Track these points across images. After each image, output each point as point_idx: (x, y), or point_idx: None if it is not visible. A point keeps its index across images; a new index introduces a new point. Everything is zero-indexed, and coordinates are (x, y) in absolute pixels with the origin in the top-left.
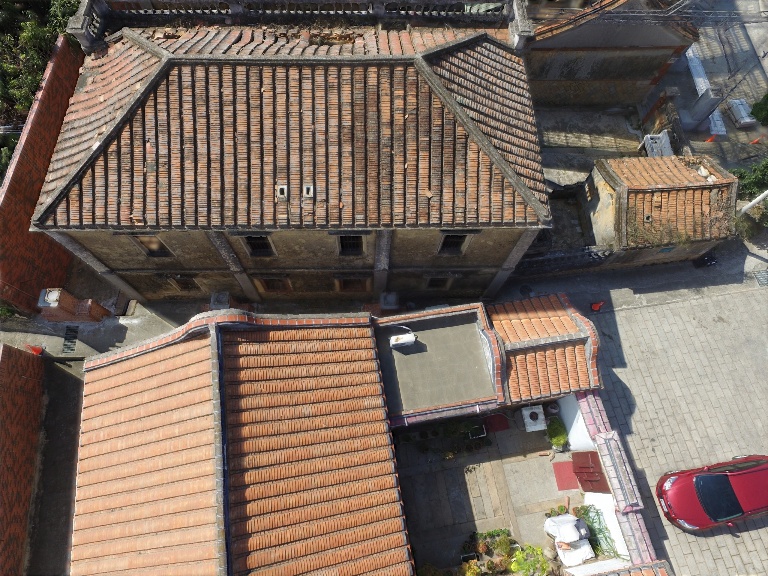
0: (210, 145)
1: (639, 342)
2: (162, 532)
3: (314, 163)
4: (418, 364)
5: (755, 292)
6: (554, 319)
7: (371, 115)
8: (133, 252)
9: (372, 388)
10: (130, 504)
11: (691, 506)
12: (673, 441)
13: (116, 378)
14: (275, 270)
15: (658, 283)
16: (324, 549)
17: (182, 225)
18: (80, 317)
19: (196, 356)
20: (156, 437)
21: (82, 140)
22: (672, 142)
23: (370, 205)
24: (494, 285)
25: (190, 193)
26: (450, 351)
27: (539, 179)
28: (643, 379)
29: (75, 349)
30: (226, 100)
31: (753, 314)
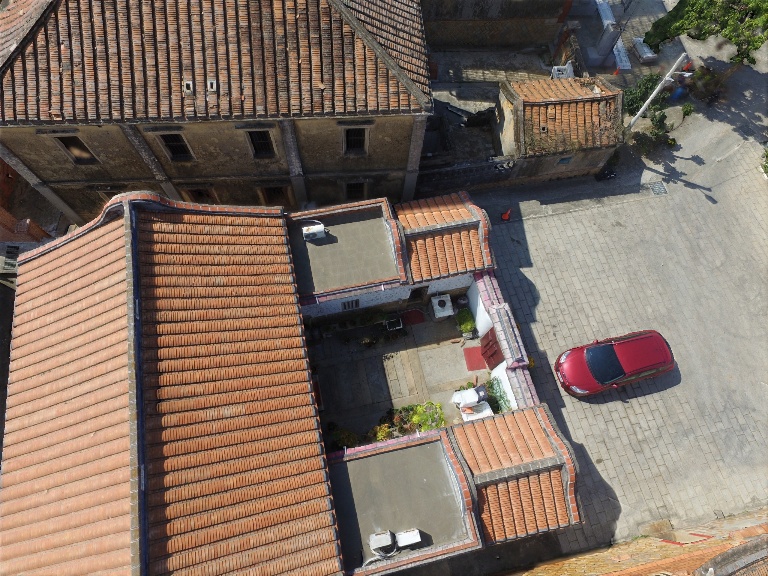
0: (120, 46)
1: (544, 245)
2: (84, 382)
3: (216, 60)
4: (329, 253)
5: (650, 200)
6: (453, 211)
7: (265, 15)
8: (60, 159)
9: (282, 267)
10: (57, 366)
11: (582, 374)
12: (572, 326)
13: (45, 266)
14: (198, 179)
15: (563, 195)
16: (231, 390)
17: (98, 119)
18: (19, 236)
19: (114, 234)
20: (80, 307)
21: (3, 48)
22: (575, 71)
23: (269, 97)
24: (406, 193)
25: (103, 89)
26: (359, 241)
27: (423, 74)
28: (547, 276)
29: (16, 266)
30: (132, 4)
31: (647, 218)
